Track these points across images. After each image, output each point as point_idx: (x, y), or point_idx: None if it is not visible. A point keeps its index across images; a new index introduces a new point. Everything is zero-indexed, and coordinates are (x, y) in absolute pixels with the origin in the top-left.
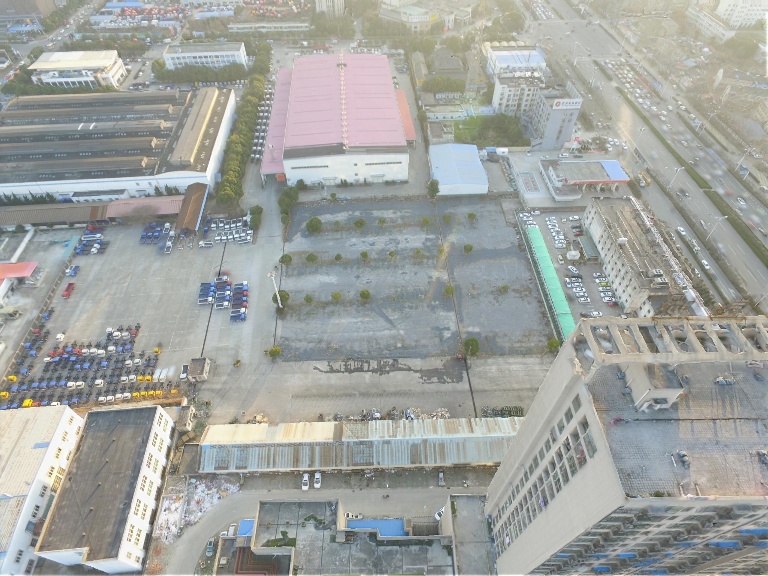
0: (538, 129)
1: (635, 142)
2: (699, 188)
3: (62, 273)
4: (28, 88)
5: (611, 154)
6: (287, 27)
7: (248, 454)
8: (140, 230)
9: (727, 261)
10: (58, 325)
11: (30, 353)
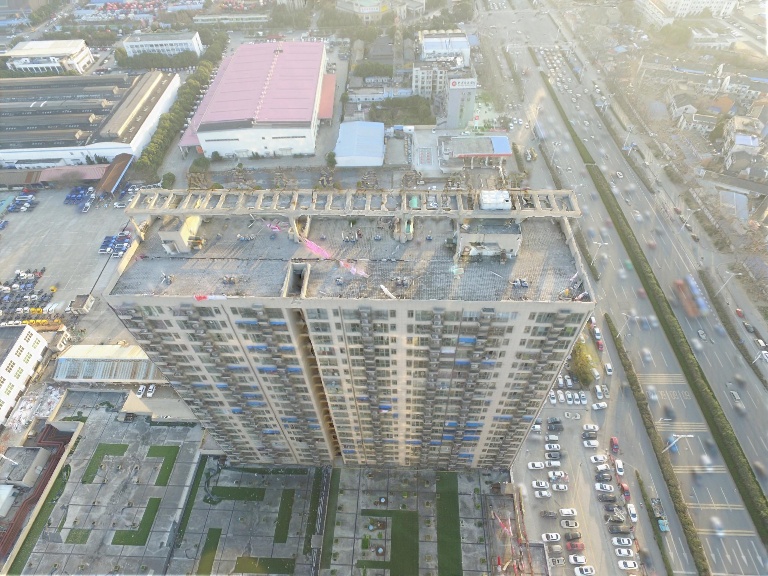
0: (445, 109)
1: (539, 122)
2: (583, 163)
3: None
4: (1, 73)
5: (512, 132)
6: (247, 19)
7: (95, 367)
8: (67, 193)
9: (580, 226)
10: None
11: None
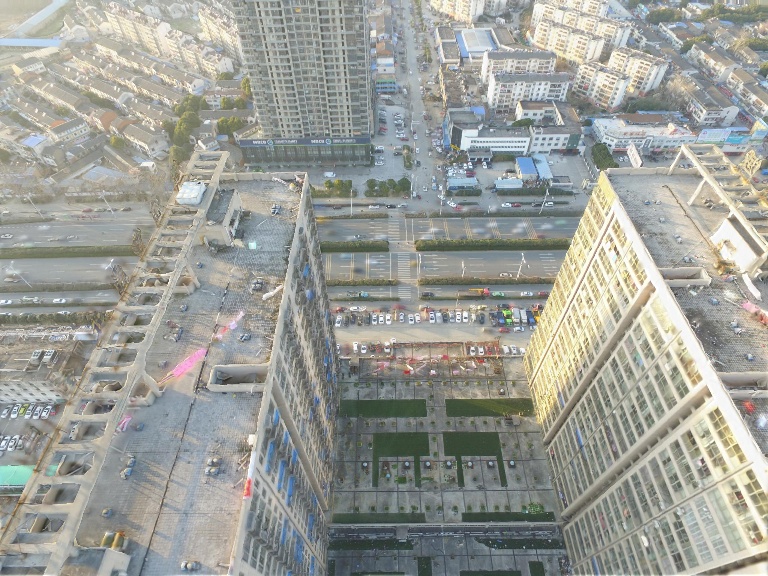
0: None
1: None
2: None
3: None
4: None
5: None
6: None
7: None
8: None
9: (66, 283)
10: None
11: None
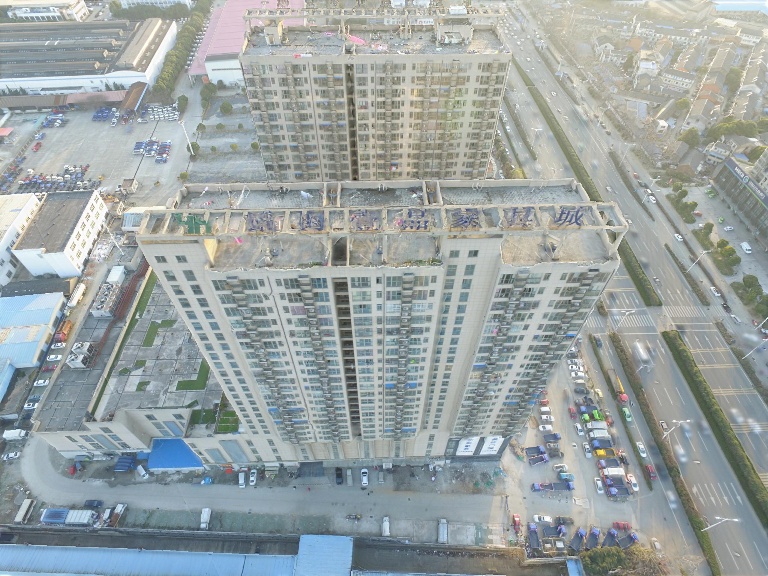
0: None
1: None
2: (525, 86)
3: (32, 137)
4: (5, 20)
5: None
6: None
7: None
8: (93, 113)
9: (522, 125)
10: (29, 166)
11: (8, 179)
